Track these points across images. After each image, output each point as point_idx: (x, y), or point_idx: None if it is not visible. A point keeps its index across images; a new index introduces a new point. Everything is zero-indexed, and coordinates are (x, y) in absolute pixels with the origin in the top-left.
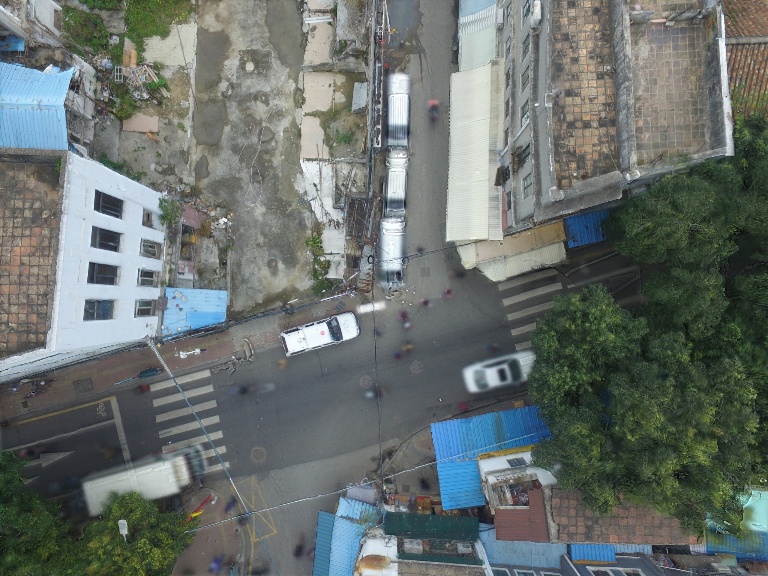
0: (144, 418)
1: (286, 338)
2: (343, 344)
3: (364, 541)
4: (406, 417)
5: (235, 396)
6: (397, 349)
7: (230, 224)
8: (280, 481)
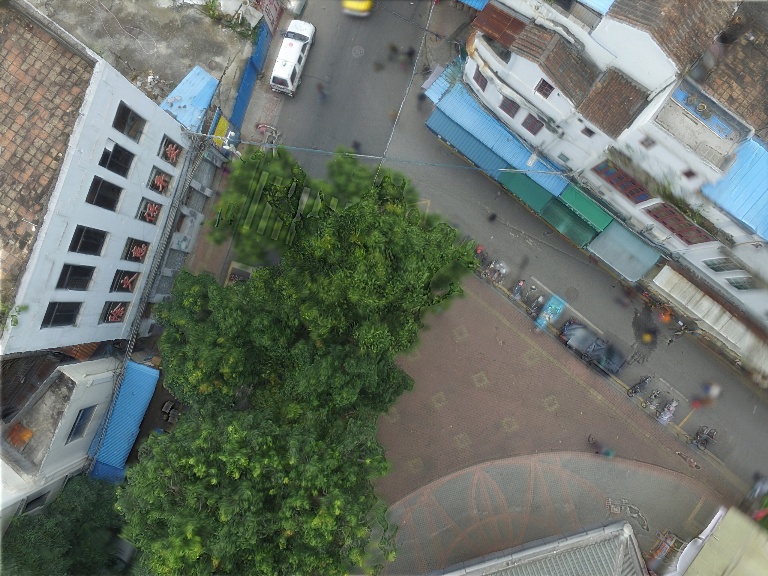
0: (266, 248)
1: (275, 73)
2: (316, 51)
3: (465, 76)
4: (407, 40)
5: None
6: (349, 11)
7: (158, 78)
8: (391, 171)
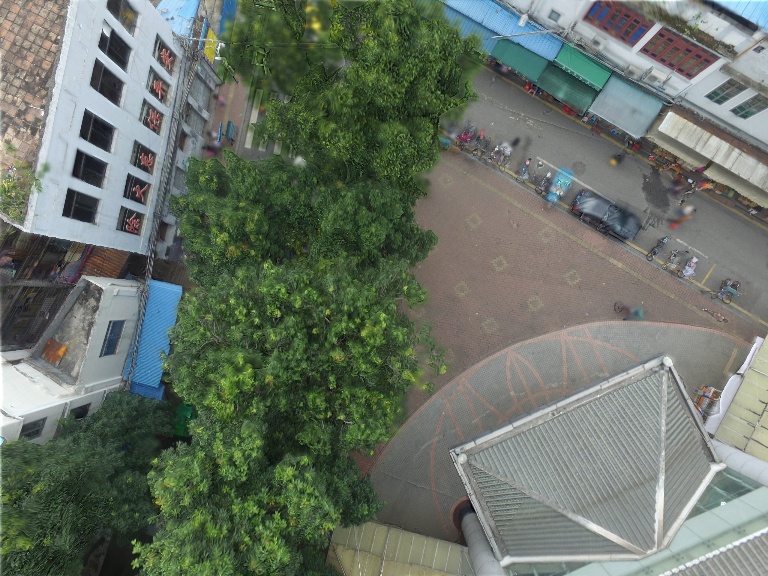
0: None
1: None
2: None
3: None
4: None
5: (291, 77)
6: None
7: None
8: None
